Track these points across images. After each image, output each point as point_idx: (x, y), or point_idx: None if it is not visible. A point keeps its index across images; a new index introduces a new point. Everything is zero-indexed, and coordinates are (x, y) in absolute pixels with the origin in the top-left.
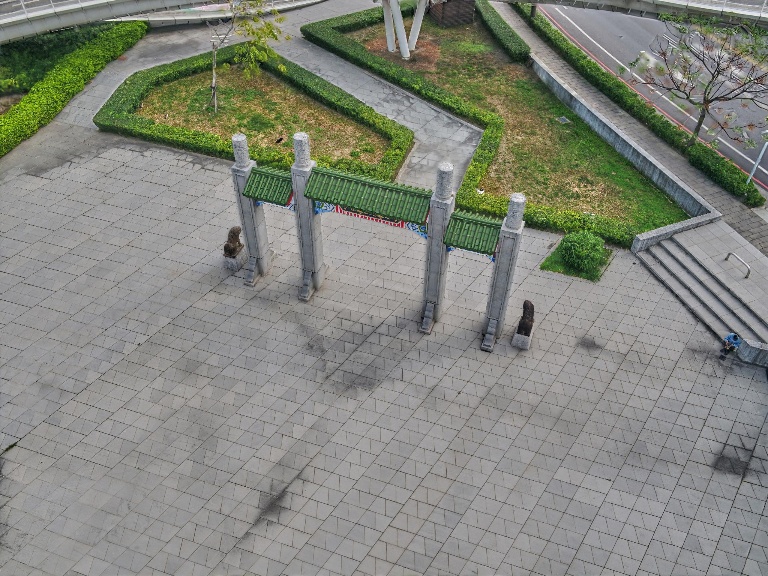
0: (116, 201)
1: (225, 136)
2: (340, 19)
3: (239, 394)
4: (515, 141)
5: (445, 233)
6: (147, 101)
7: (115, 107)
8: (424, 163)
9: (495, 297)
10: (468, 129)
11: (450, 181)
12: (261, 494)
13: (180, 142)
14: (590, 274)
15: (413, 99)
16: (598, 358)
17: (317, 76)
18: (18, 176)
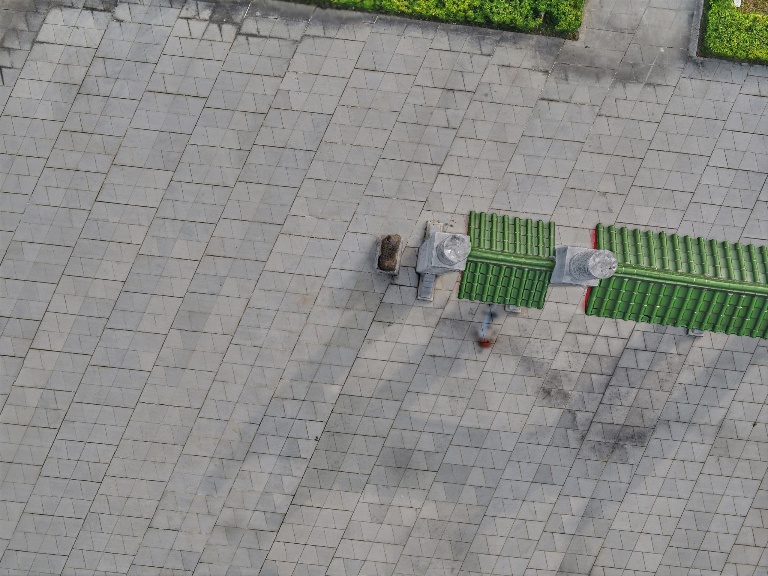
0: (134, 155)
1: None
2: None
3: (479, 488)
4: None
5: None
6: None
7: None
8: None
9: None
10: None
11: None
12: None
13: None
14: None
15: None
16: None
17: None
18: None
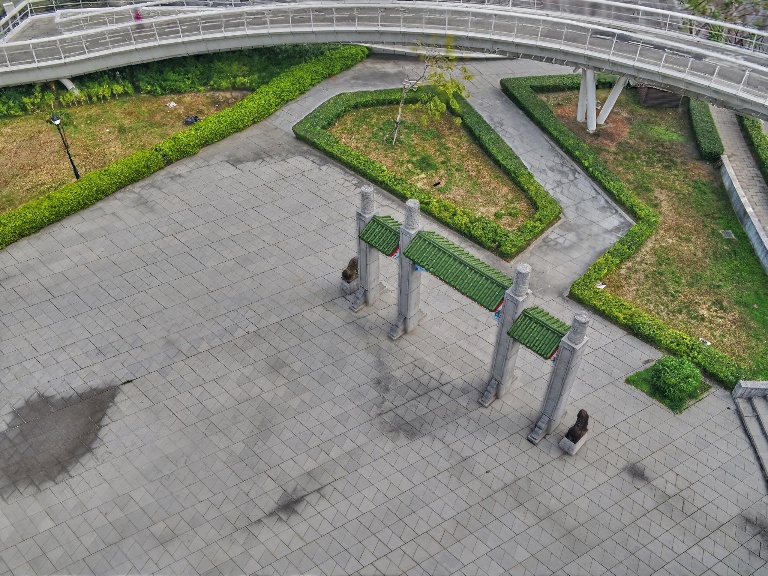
0: (282, 204)
1: (392, 168)
2: (542, 79)
3: (304, 402)
4: (664, 243)
5: (513, 325)
6: (342, 120)
7: (313, 121)
8: (560, 241)
9: (550, 397)
10: (621, 218)
11: (525, 281)
12: (284, 493)
13: (352, 165)
14: (674, 403)
15: (579, 174)
16: (639, 490)
17: (494, 131)
18: (220, 162)
